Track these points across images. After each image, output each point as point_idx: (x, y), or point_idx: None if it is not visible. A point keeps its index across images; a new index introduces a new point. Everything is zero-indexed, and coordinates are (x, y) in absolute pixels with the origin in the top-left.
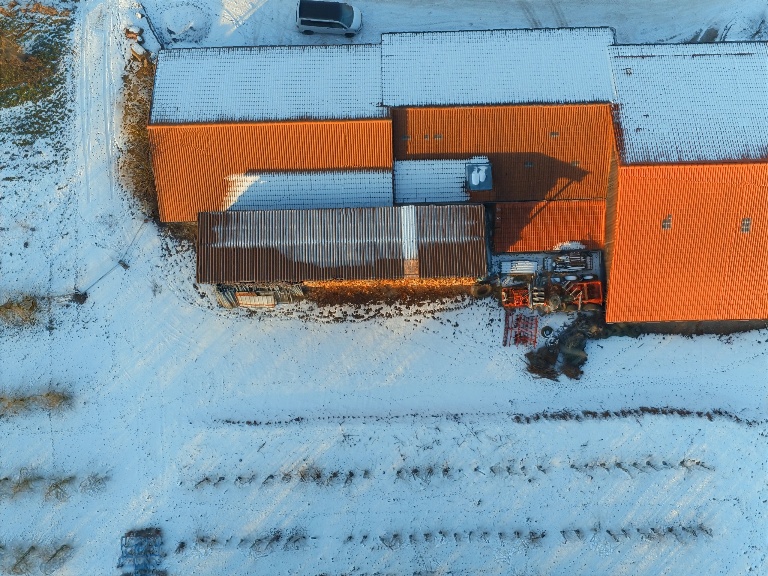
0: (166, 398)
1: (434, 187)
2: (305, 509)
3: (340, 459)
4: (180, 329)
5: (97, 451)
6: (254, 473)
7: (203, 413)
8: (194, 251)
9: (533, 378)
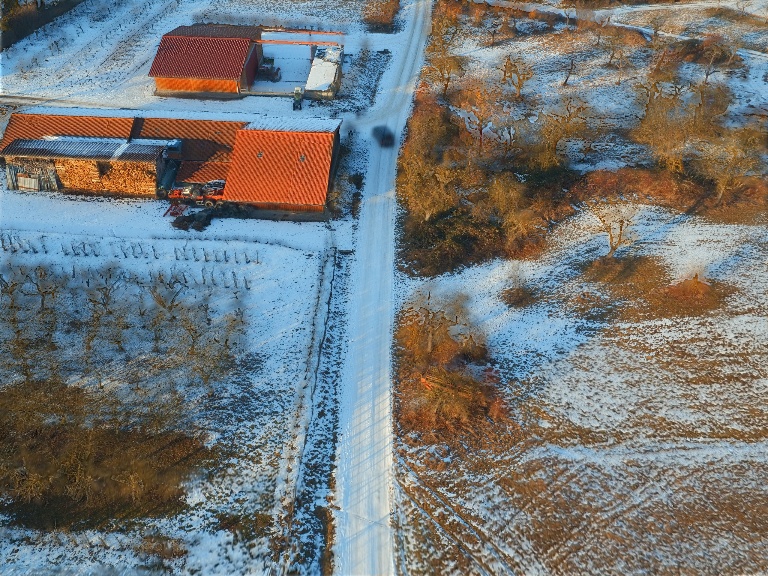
0: None
1: None
2: None
3: (34, 245)
4: None
5: None
6: None
7: None
8: None
9: (174, 229)
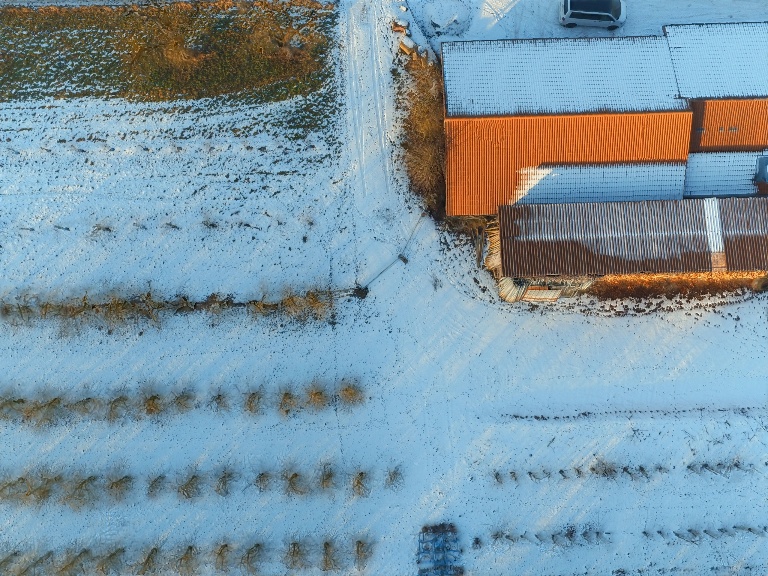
0: (452, 393)
1: (723, 180)
2: (597, 504)
3: (630, 454)
4: (463, 323)
5: (385, 446)
6: (544, 468)
7: (489, 408)
8: (472, 245)
9: None
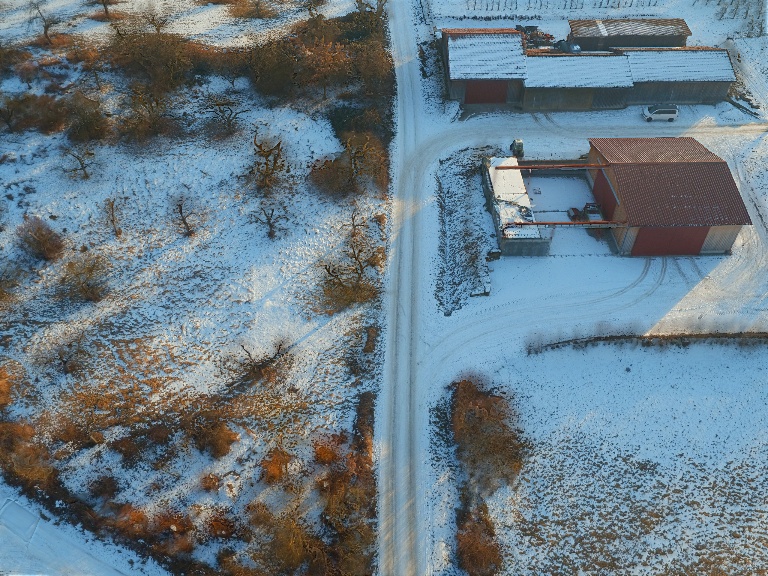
0: None
1: None
2: None
3: None
4: None
5: None
6: (637, 7)
7: (663, 18)
8: None
9: None
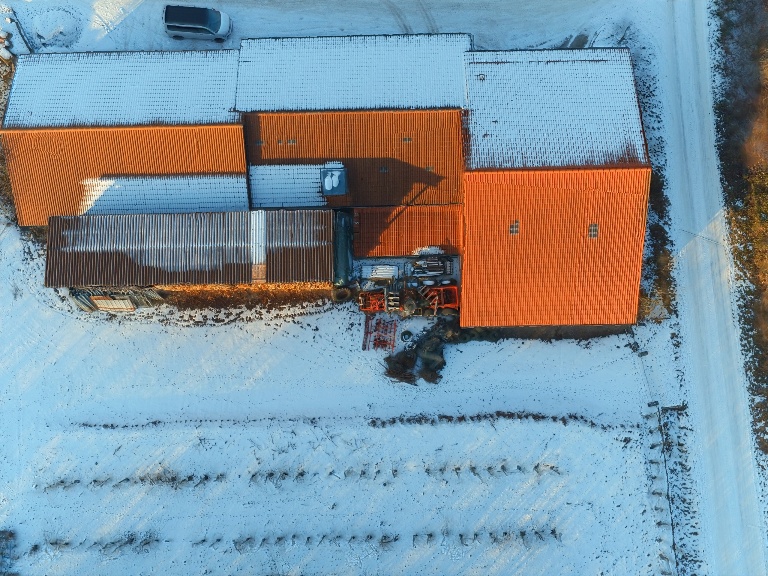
0: (24, 401)
1: (290, 192)
2: (159, 512)
3: (196, 462)
4: (40, 332)
5: None
6: (109, 476)
7: (61, 416)
8: None
9: (392, 382)
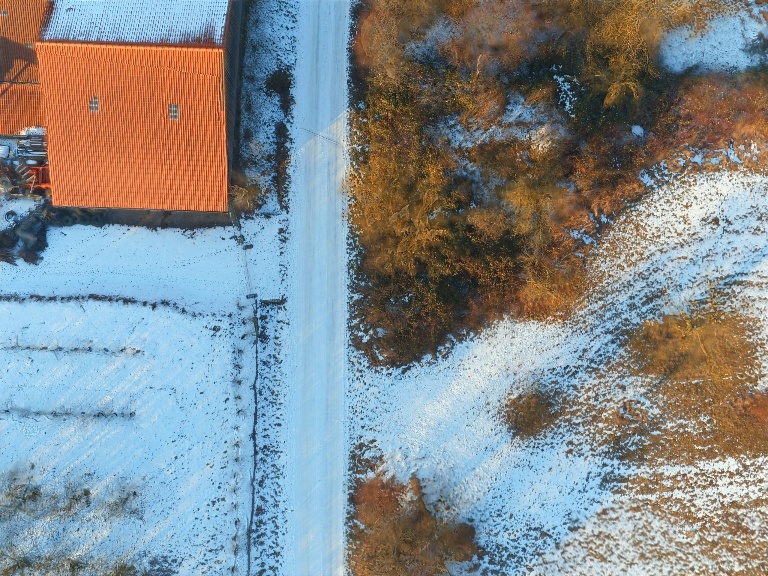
0: None
1: None
2: None
3: None
4: None
5: None
6: None
7: None
8: None
9: None
